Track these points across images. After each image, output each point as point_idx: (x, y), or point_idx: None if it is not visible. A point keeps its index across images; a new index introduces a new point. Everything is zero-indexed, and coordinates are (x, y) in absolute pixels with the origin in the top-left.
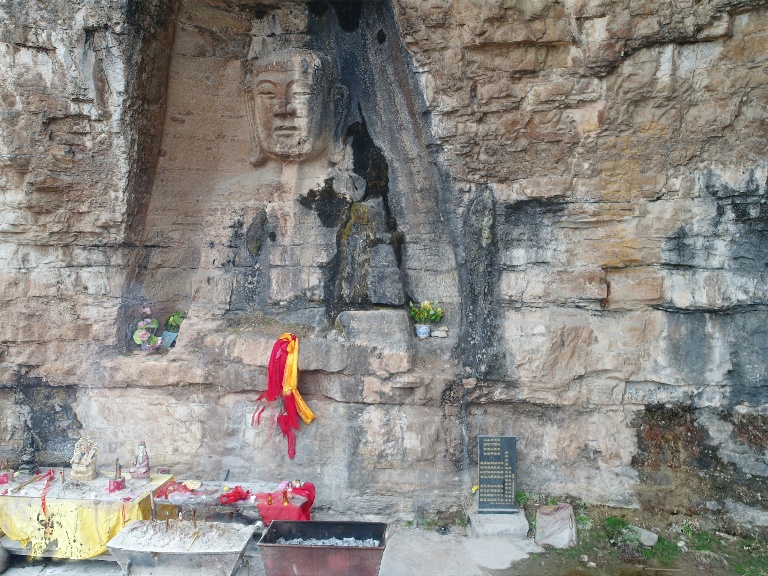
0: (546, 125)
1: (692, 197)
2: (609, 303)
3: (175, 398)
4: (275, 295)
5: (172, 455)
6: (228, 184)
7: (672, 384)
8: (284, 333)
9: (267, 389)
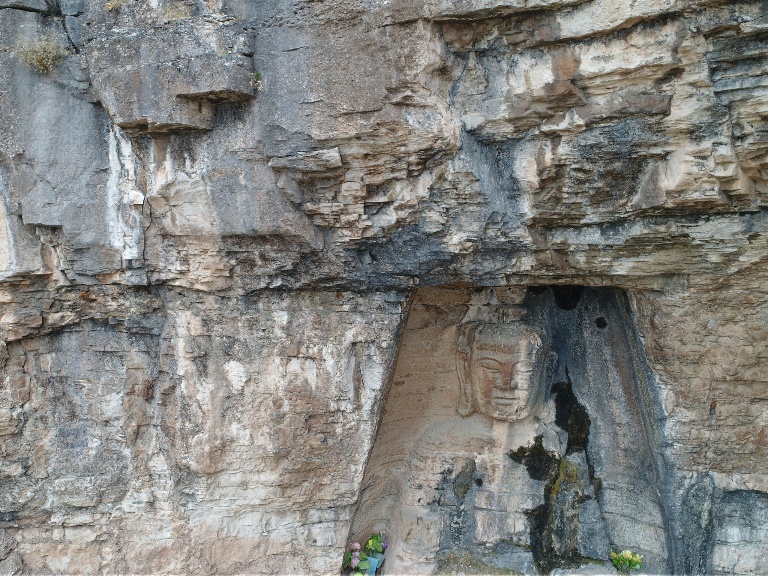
0: None
1: None
2: None
3: None
4: (481, 536)
5: None
6: (438, 433)
7: None
8: None
9: None
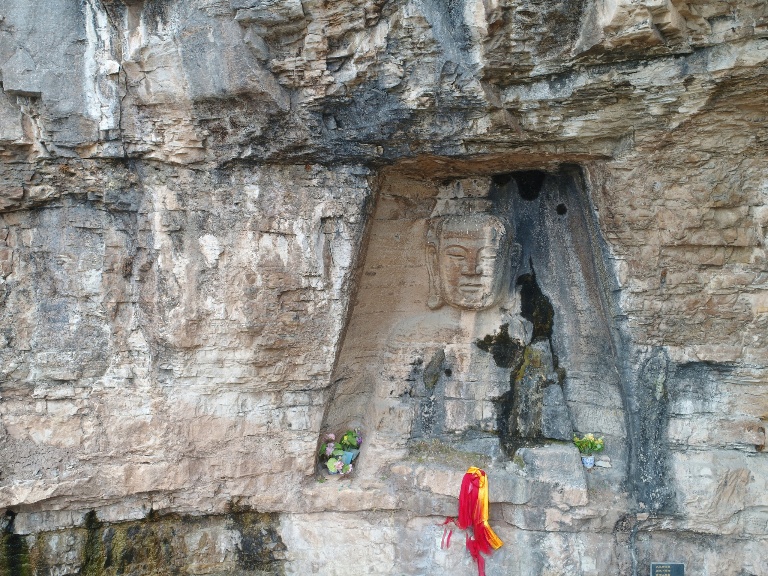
0: (724, 305)
1: None
2: (764, 447)
3: (369, 522)
4: (450, 424)
5: (369, 574)
6: (409, 326)
7: None
8: (468, 465)
9: (455, 516)
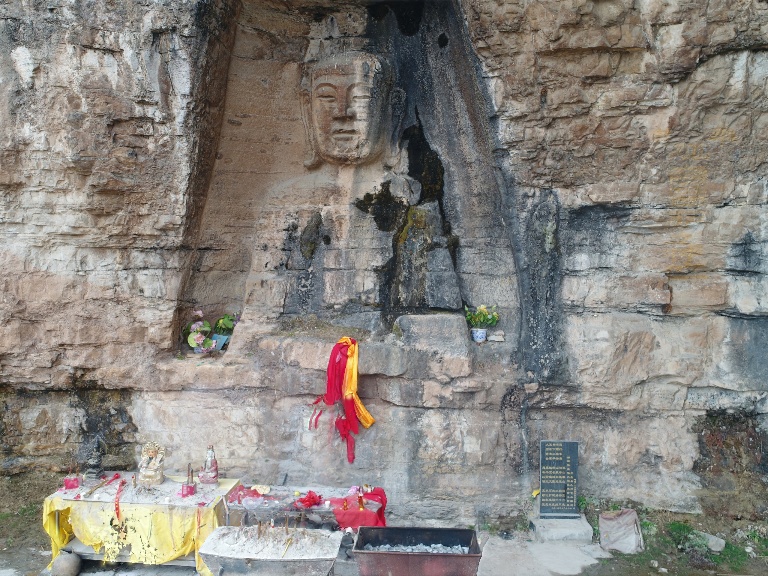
0: (615, 131)
1: (760, 203)
2: (671, 308)
3: (231, 401)
4: (329, 298)
5: (228, 459)
6: (282, 187)
7: (735, 390)
8: (341, 337)
9: (325, 393)
